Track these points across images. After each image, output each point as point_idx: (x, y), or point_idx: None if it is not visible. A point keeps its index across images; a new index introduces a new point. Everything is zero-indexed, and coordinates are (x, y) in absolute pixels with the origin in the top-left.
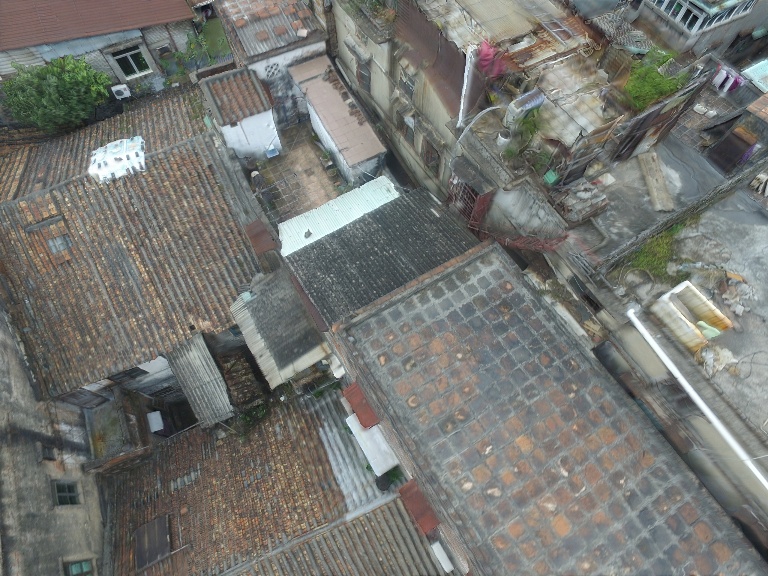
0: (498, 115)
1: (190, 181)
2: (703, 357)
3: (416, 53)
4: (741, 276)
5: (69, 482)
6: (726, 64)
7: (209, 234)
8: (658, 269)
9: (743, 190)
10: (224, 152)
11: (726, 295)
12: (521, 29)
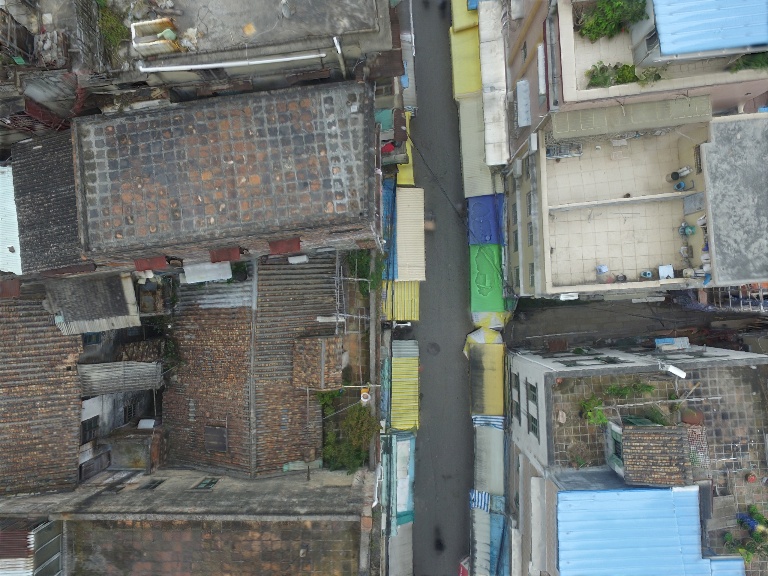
0: None
1: None
2: (184, 47)
3: None
4: None
5: (148, 483)
6: None
7: None
8: (124, 33)
9: None
10: None
11: (159, 4)
12: None
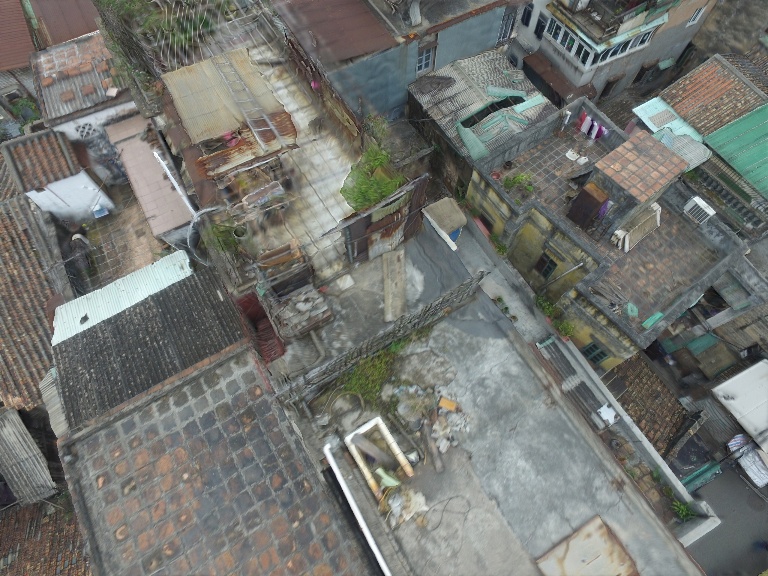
0: None
1: (3, 247)
2: (389, 505)
3: (177, 132)
4: (457, 402)
5: None
6: (637, 93)
7: (22, 303)
8: (370, 394)
9: (604, 245)
10: (39, 216)
11: (436, 426)
12: (228, 127)
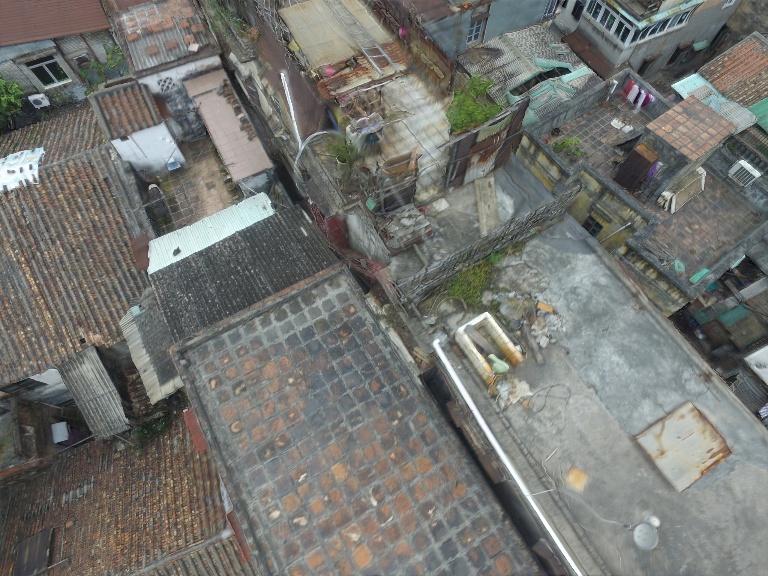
0: (344, 137)
1: (85, 194)
2: (498, 390)
3: (274, 73)
4: (553, 306)
5: None
6: (671, 75)
7: (103, 247)
8: (472, 298)
9: (650, 207)
10: (120, 165)
11: (535, 326)
12: (343, 55)
